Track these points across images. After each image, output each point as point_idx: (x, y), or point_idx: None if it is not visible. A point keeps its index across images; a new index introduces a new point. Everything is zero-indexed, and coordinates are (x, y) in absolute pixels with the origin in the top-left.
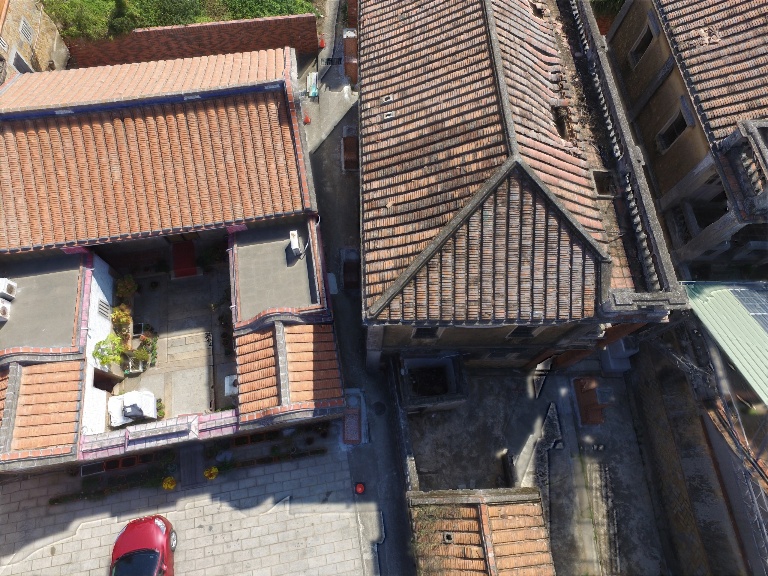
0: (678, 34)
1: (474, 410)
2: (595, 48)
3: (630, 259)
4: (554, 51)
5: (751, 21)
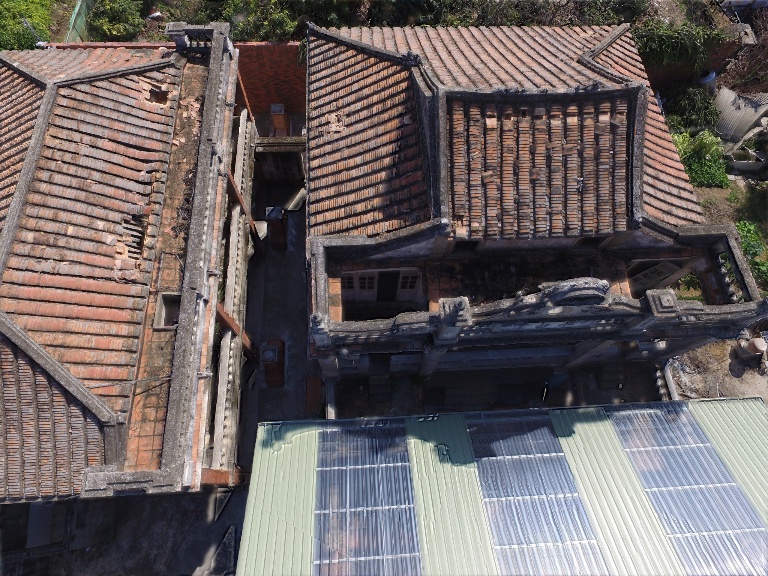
0: (314, 118)
1: (137, 539)
2: (200, 141)
3: None
4: (157, 145)
5: (373, 107)
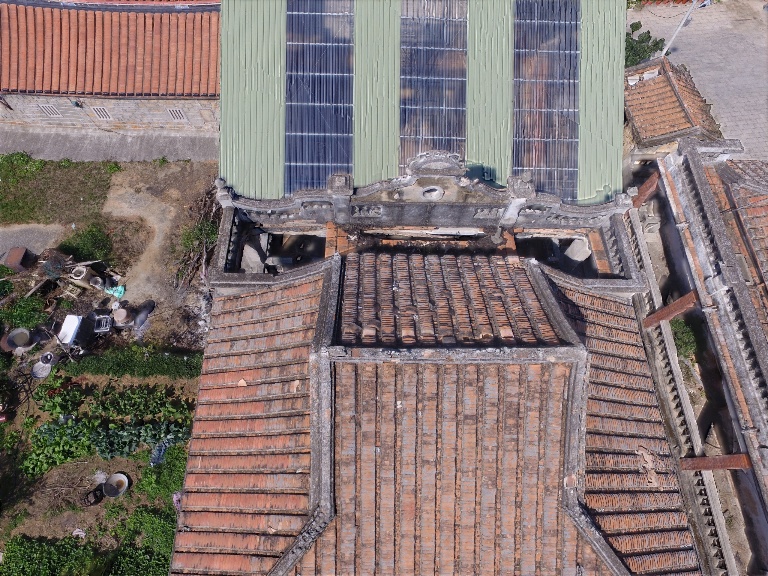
0: (675, 492)
1: None
2: None
3: (699, 199)
4: None
5: None
